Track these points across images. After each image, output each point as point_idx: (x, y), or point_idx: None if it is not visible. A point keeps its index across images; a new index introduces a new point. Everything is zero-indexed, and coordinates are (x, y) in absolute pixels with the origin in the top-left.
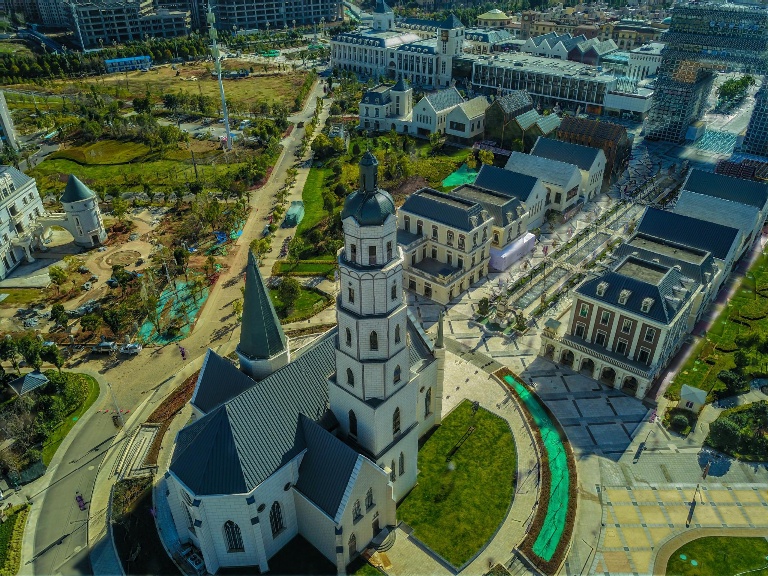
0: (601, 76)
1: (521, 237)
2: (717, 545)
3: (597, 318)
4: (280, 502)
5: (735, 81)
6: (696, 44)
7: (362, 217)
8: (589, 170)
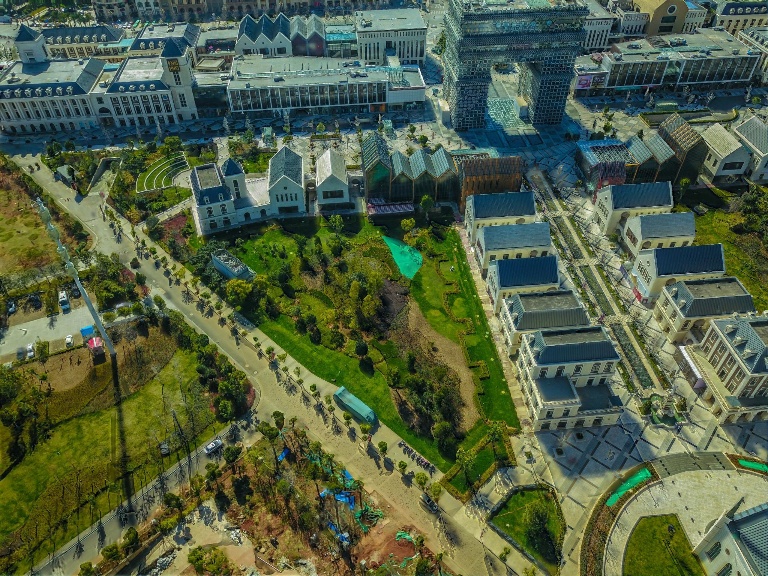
0: (371, 74)
1: None
2: None
3: (764, 382)
4: None
5: (445, 38)
6: (489, 45)
7: None
8: (535, 214)
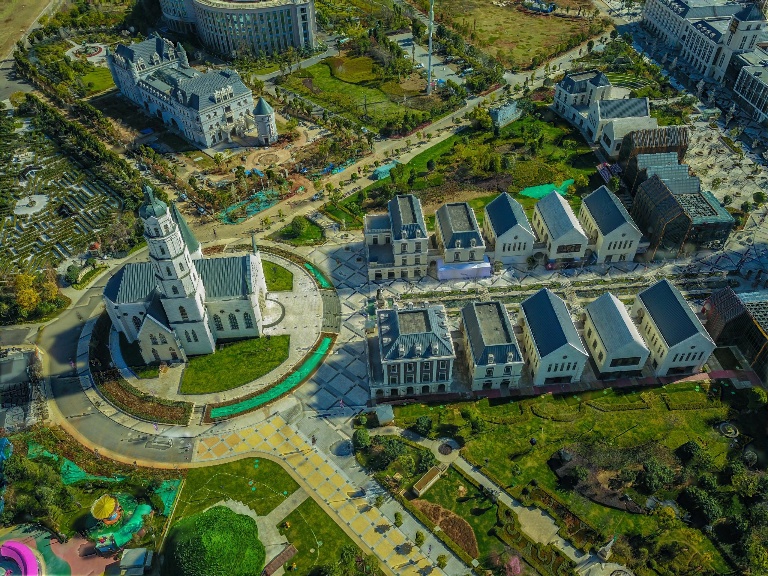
0: None
1: (474, 263)
2: (276, 470)
3: None
4: (139, 318)
5: None
6: None
7: (140, 212)
8: (604, 236)
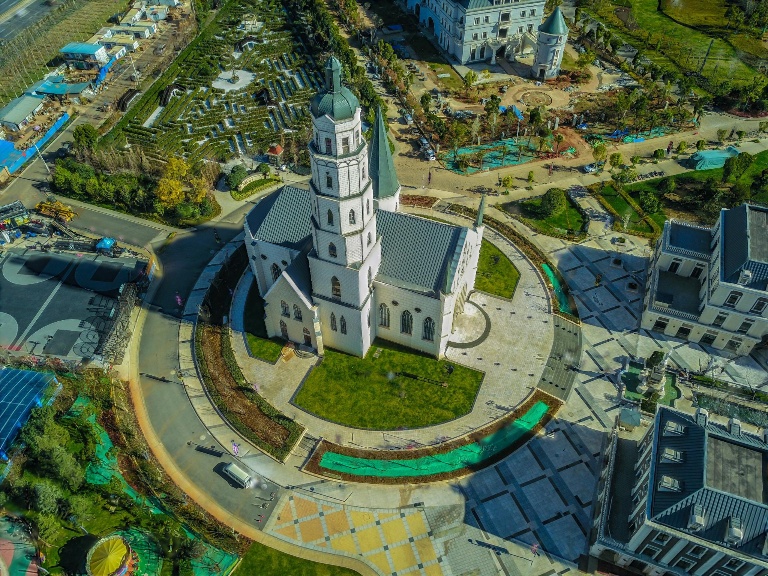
0: None
1: None
2: None
3: (649, 452)
4: None
5: None
6: None
7: (312, 104)
8: None
